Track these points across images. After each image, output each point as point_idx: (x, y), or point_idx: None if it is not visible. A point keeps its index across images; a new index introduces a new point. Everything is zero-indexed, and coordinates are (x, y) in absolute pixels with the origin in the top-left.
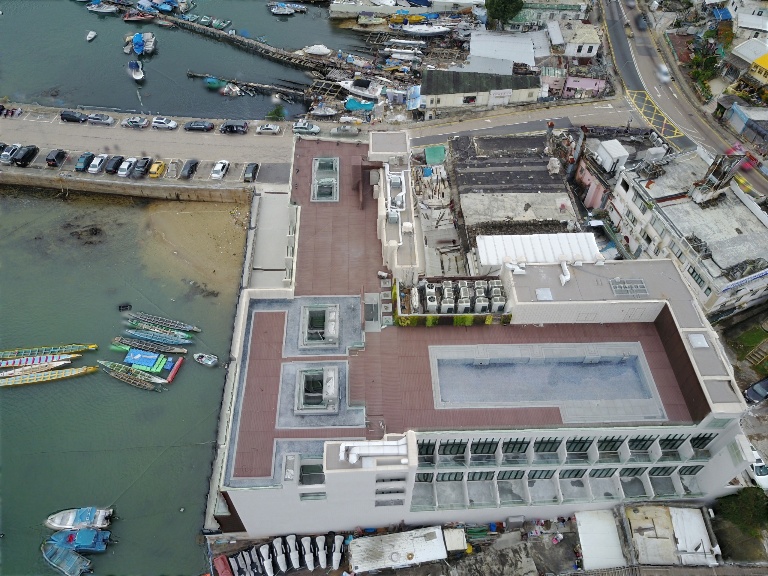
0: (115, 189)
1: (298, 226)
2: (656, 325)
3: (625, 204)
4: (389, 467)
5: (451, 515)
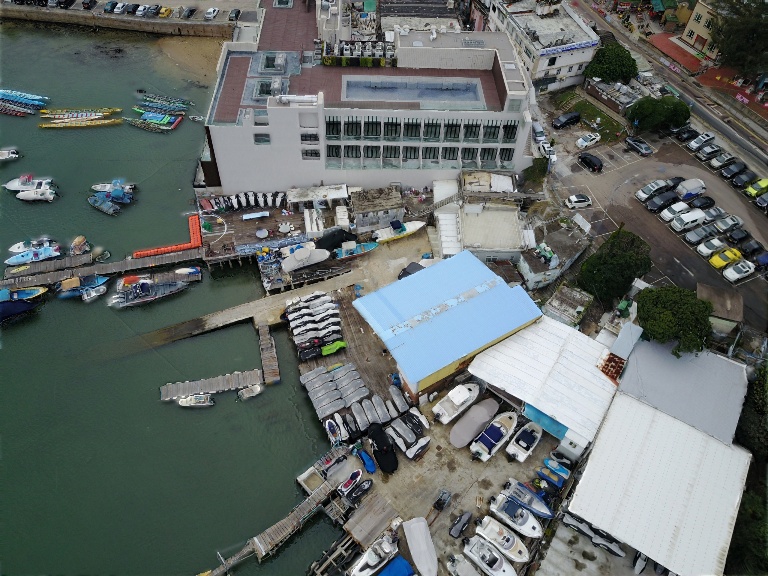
0: (133, 26)
1: (263, 18)
2: (492, 70)
3: (494, 22)
4: (306, 107)
5: (353, 178)
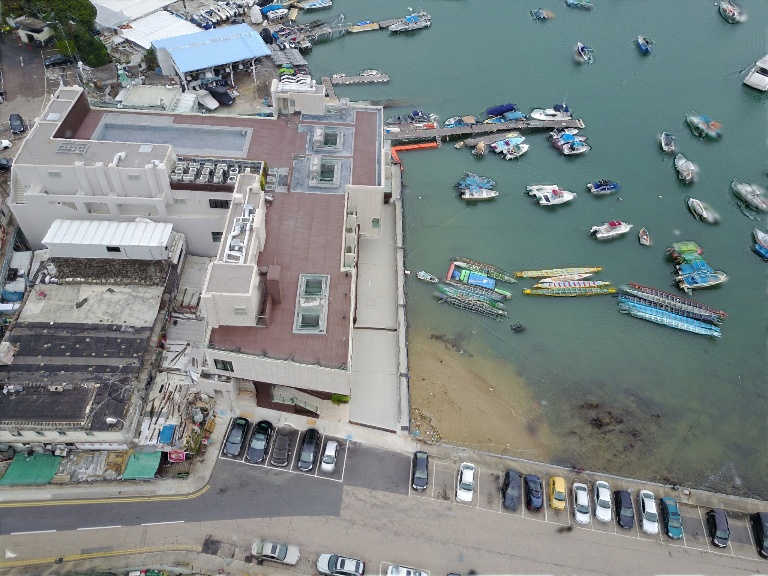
0: None
1: (343, 249)
2: None
3: None
4: None
5: None
